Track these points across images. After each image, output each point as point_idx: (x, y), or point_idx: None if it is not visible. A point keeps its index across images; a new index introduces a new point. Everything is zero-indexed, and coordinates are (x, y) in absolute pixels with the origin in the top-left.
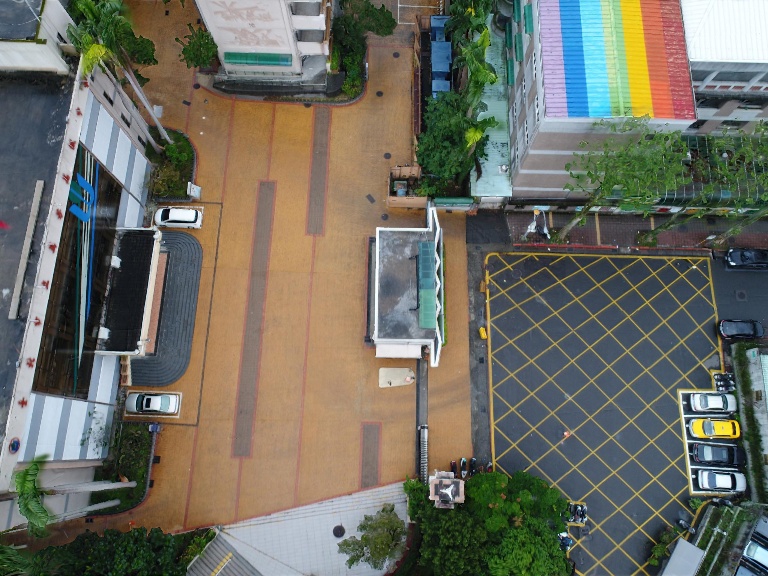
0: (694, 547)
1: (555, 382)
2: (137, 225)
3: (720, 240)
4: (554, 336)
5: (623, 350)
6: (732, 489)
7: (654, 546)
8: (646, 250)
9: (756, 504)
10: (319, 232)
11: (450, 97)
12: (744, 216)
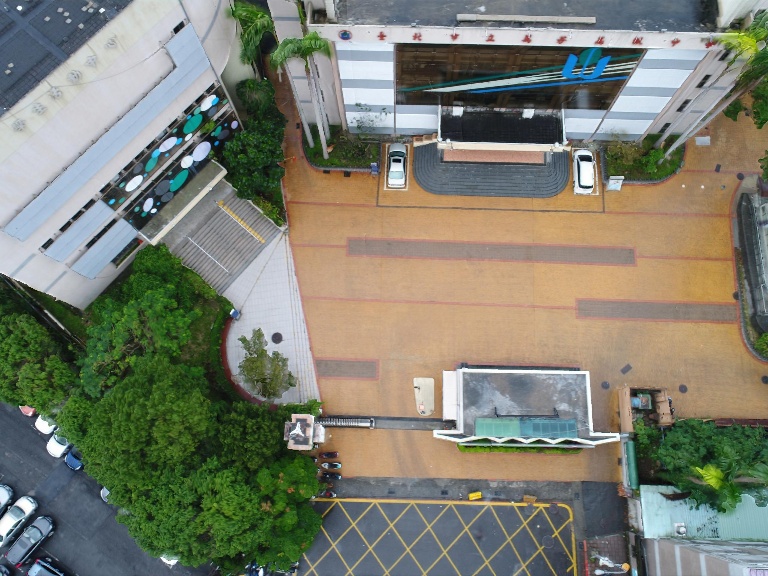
0: None
1: None
2: (571, 132)
3: None
4: None
5: None
6: None
7: None
8: None
9: None
10: (581, 313)
11: (767, 455)
12: None
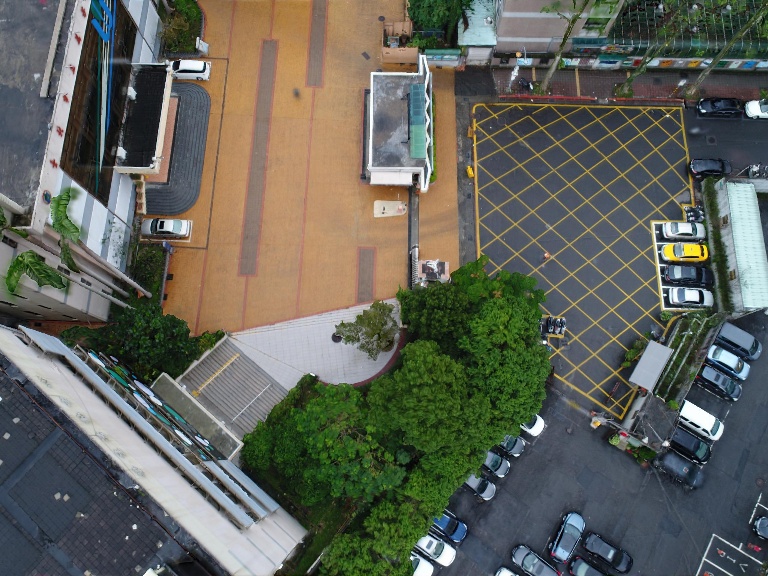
0: (663, 346)
1: (537, 214)
2: None
3: (692, 90)
4: (536, 175)
5: (600, 187)
6: (700, 303)
7: (627, 351)
8: (623, 101)
9: (721, 311)
10: (318, 84)
11: None
12: (714, 70)
